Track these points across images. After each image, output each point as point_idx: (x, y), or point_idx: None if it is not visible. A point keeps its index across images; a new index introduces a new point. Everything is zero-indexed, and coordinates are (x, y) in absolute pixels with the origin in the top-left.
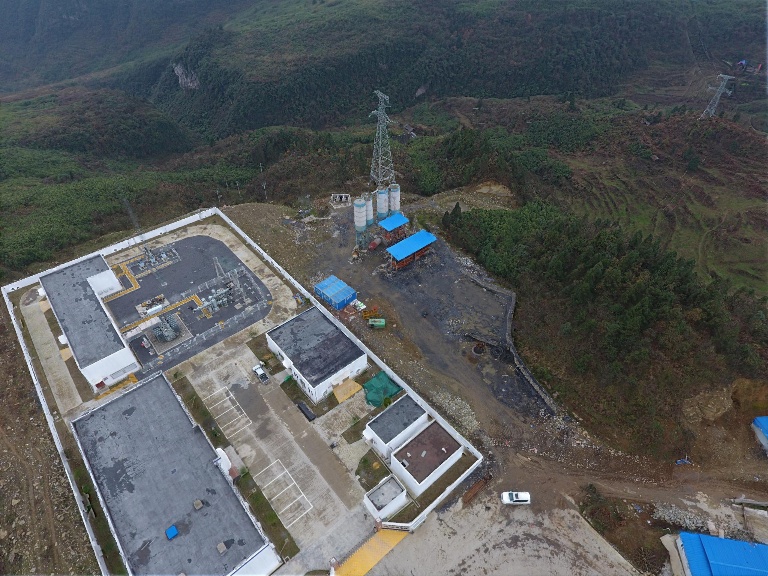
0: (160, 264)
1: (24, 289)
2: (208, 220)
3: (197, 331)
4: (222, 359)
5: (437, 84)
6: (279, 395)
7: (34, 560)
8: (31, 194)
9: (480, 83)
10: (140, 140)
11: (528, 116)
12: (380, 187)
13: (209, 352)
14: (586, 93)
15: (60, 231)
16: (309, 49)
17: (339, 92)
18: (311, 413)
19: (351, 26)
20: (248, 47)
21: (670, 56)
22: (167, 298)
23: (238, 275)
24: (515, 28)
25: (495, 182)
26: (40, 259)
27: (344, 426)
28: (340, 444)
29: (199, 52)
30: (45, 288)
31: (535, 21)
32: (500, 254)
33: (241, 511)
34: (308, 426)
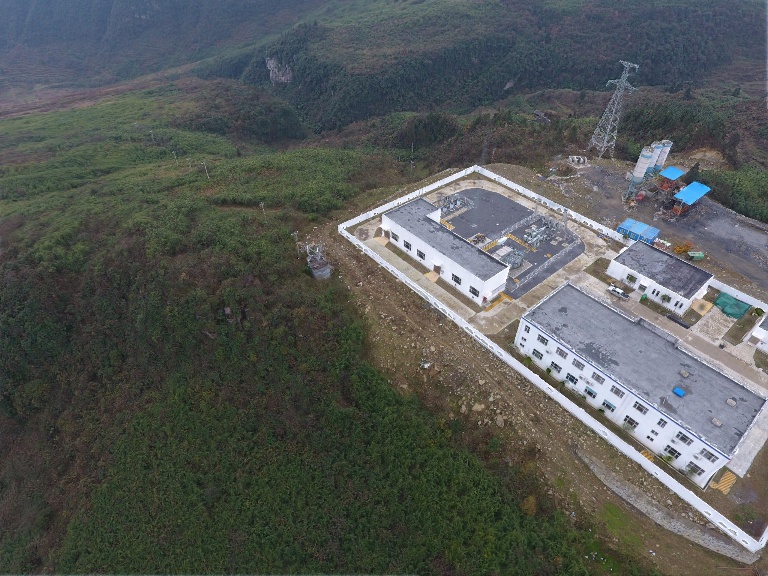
0: (458, 210)
1: (352, 228)
2: (472, 176)
3: (533, 261)
4: (572, 282)
5: (525, 78)
6: (644, 309)
7: (529, 423)
8: (267, 159)
9: (568, 77)
10: (267, 126)
11: (640, 105)
12: (656, 142)
13: (556, 277)
14: (696, 83)
15: (335, 186)
16: (407, 43)
17: (435, 85)
18: (685, 322)
19: (444, 22)
20: (345, 42)
21: (754, 52)
22: (485, 236)
23: (534, 219)
24: (603, 24)
25: (711, 148)
26: (335, 207)
27: (720, 332)
28: (727, 345)
29: (296, 46)
30: (395, 222)
31: (622, 17)
32: (761, 204)
33: (724, 379)
34: (688, 332)
